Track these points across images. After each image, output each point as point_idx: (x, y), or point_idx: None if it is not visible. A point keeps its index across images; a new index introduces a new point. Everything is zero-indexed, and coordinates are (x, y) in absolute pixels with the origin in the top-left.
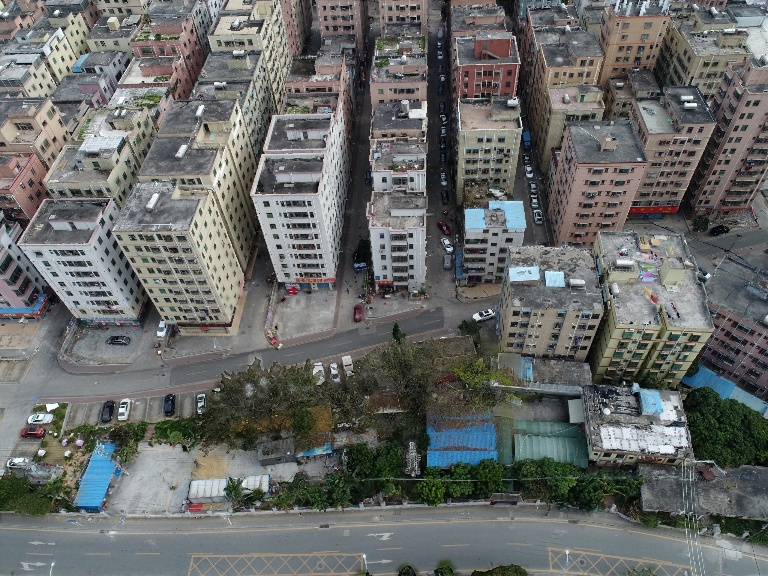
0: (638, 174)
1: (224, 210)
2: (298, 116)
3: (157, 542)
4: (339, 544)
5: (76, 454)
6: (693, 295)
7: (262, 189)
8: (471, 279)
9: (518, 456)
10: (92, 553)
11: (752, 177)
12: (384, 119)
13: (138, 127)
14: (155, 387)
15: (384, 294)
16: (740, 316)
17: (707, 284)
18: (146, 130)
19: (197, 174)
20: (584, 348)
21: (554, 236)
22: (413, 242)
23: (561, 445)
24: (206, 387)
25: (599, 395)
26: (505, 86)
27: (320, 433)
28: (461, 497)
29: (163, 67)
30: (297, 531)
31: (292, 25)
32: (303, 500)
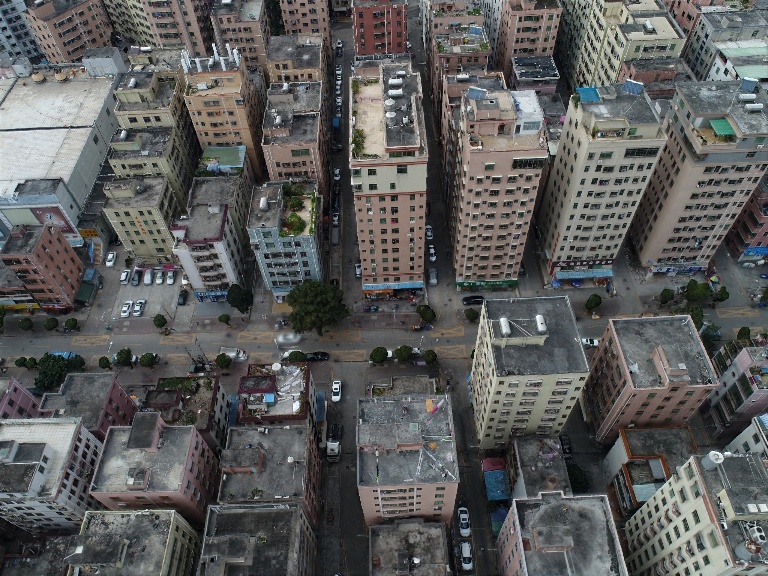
0: None
1: None
2: None
3: None
4: None
5: None
6: None
7: None
8: None
9: None
10: None
11: None
12: None
13: None
14: None
15: None
16: None
17: None
18: None
19: None
20: None
21: None
22: None
23: None
24: None
25: None
26: None
27: None
28: None
29: None
30: None
31: None
32: None
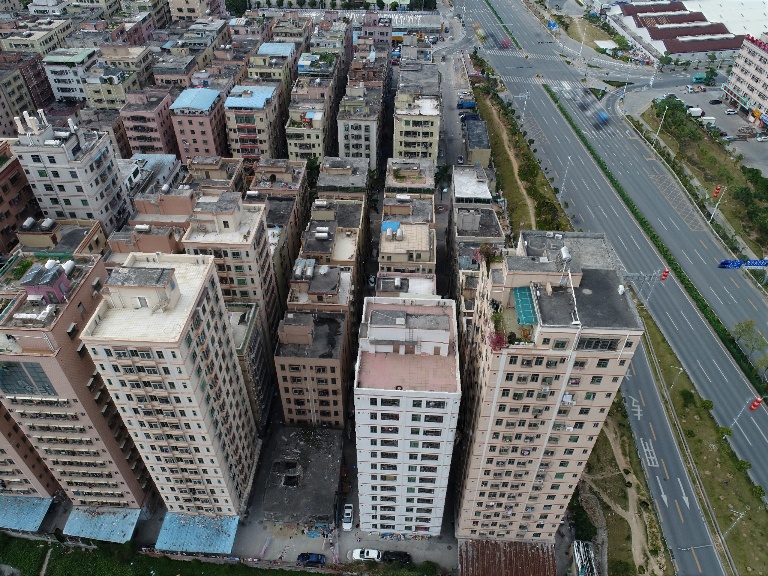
0: None
1: None
2: (46, 7)
3: None
4: None
5: None
6: None
7: None
8: None
9: None
10: None
11: None
12: None
13: None
14: None
15: None
16: None
17: None
18: None
19: None
20: None
21: None
22: None
23: None
24: None
25: None
26: None
27: None
28: None
29: None
30: None
31: None
32: None
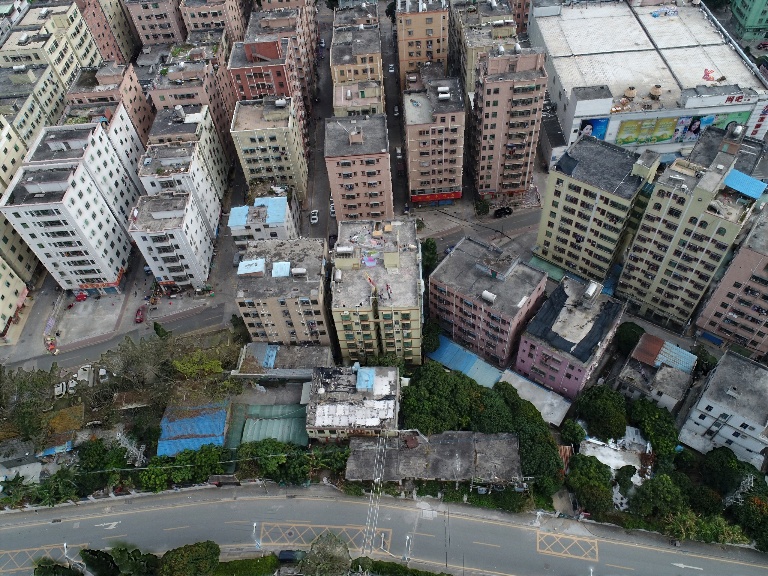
0: (385, 164)
1: None
2: (66, 127)
3: None
4: (67, 536)
5: None
6: (410, 276)
7: (12, 201)
8: None
9: (245, 439)
10: None
11: (519, 160)
12: (161, 125)
13: None
14: None
15: (171, 294)
16: (465, 292)
17: (443, 264)
18: None
19: None
20: (323, 333)
21: None
22: (177, 242)
23: (287, 426)
24: None
25: (323, 376)
26: (279, 87)
27: None
28: (185, 482)
29: None
30: (29, 528)
31: (108, 36)
32: (33, 497)
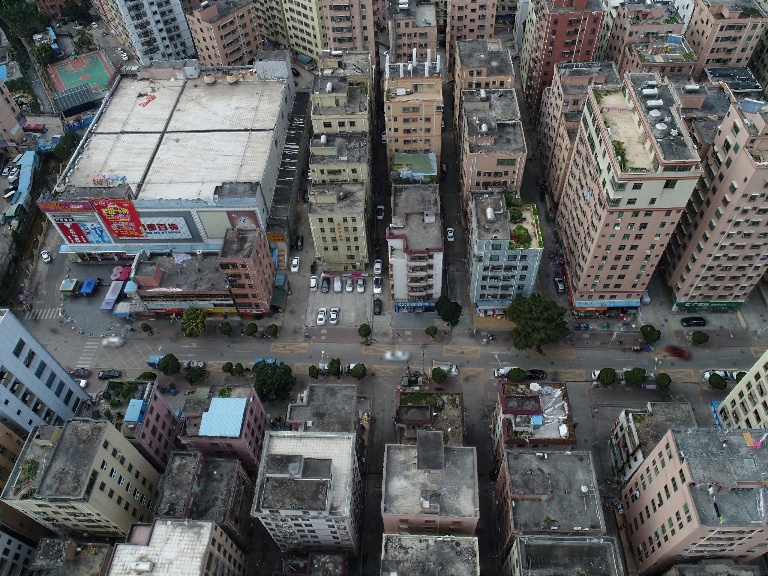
0: None
1: None
2: None
3: None
4: None
5: None
6: None
7: None
8: None
9: None
10: None
11: None
12: None
13: None
14: None
15: None
16: None
17: None
18: None
19: None
20: None
21: None
22: None
23: None
24: None
25: None
26: None
27: None
28: None
29: None
30: None
31: None
32: None
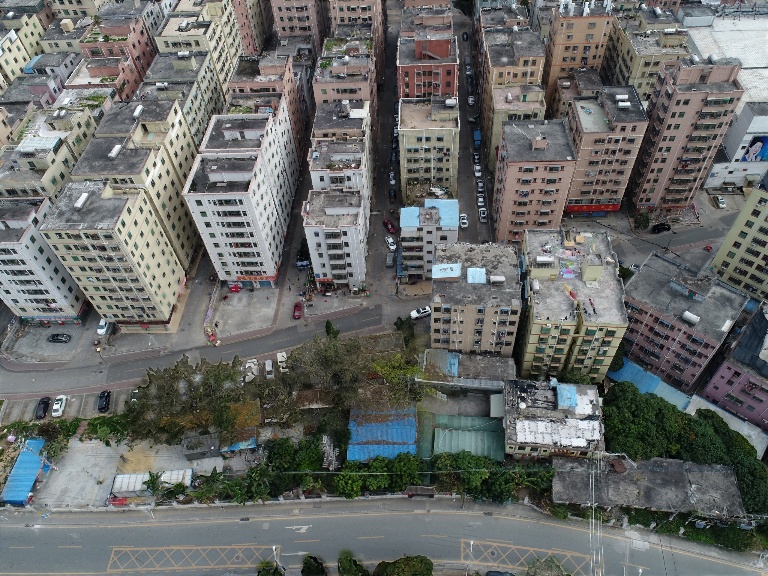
0: (568, 172)
1: (160, 209)
2: (237, 116)
3: (80, 535)
4: (258, 537)
5: (8, 450)
6: (612, 291)
7: (195, 188)
8: (412, 277)
9: (437, 450)
10: (16, 546)
11: (689, 175)
12: (325, 119)
13: (78, 127)
14: (92, 384)
15: (325, 292)
16: (661, 312)
17: (632, 280)
18: (87, 130)
19: (128, 173)
20: (509, 344)
21: (495, 234)
22: (348, 240)
23: (480, 439)
24: (142, 384)
25: (518, 390)
26: (445, 86)
27: (246, 428)
28: (378, 490)
29: (110, 68)
30: (218, 524)
31: (248, 26)
32: (223, 494)
